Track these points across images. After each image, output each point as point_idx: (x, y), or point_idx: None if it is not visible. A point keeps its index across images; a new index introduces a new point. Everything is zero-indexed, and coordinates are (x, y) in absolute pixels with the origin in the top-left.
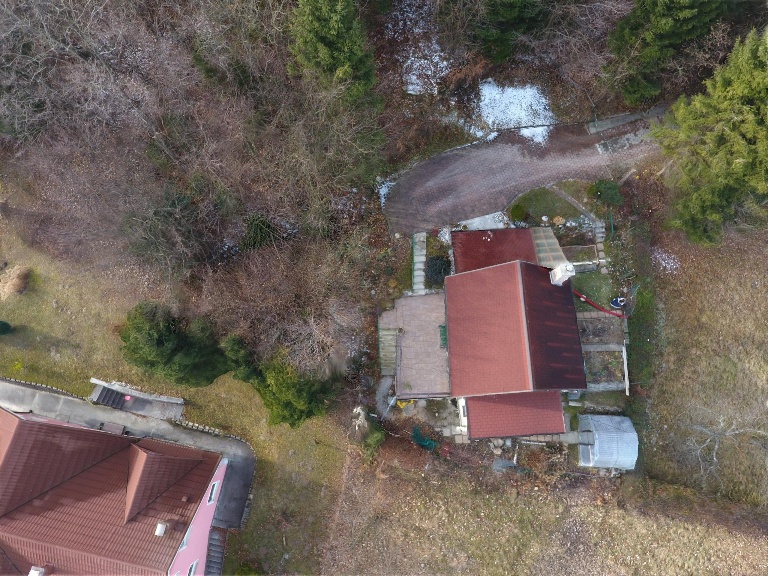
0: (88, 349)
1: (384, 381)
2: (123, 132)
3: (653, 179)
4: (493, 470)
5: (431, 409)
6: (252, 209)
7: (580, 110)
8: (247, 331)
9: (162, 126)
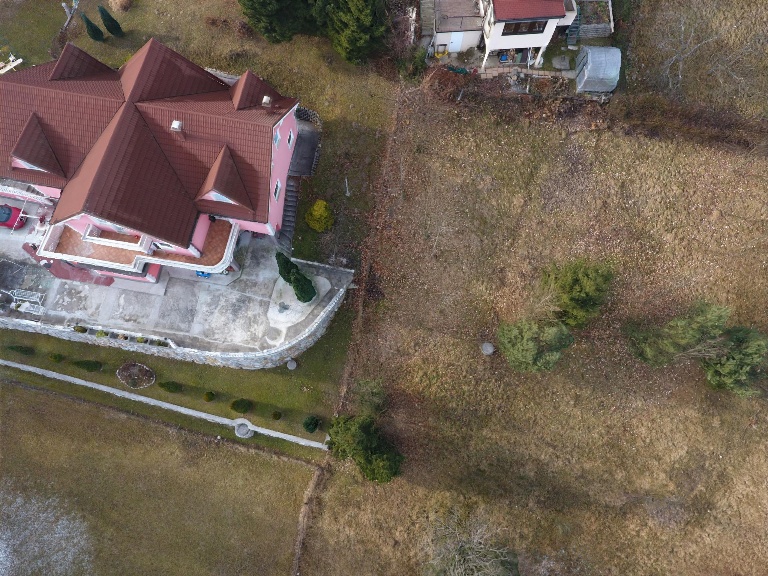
0: (186, 39)
1: (424, 40)
2: None
3: None
4: (511, 93)
5: (461, 58)
6: None
7: None
8: None
9: None
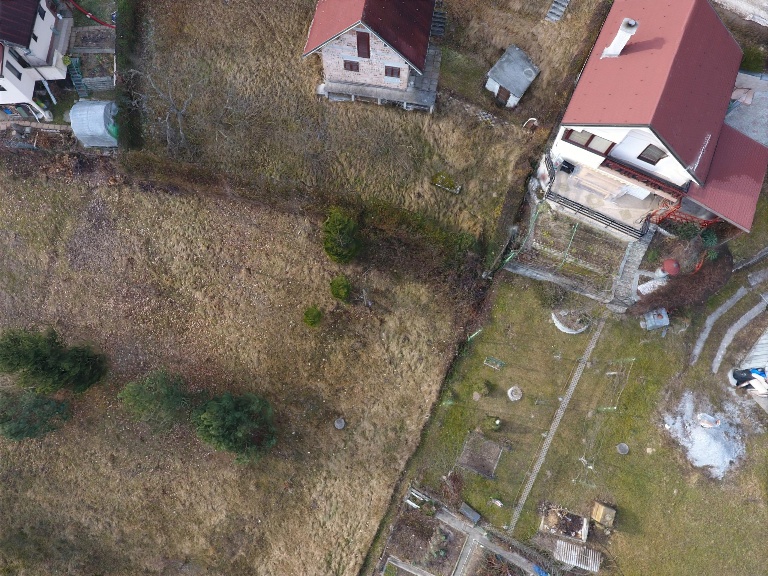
0: None
1: None
2: None
3: None
4: None
5: None
6: None
7: None
8: None
9: None
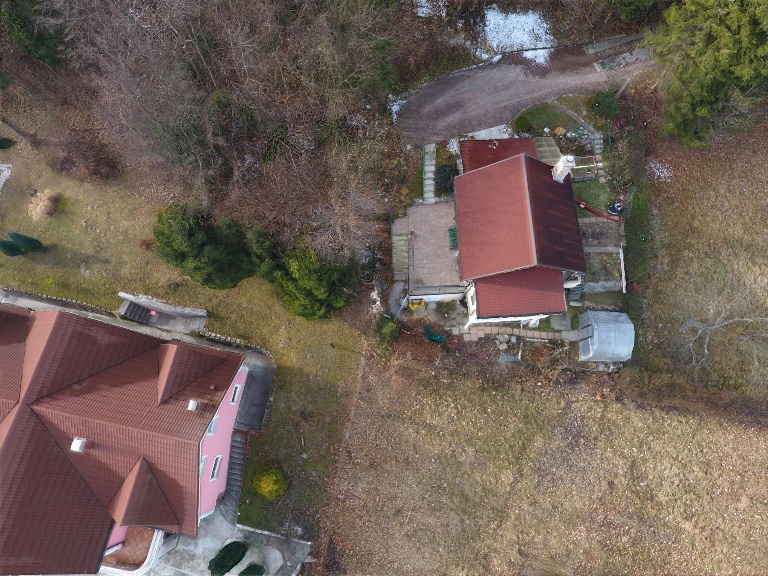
0: (117, 263)
1: (396, 286)
2: (148, 61)
3: (648, 93)
4: (499, 364)
5: (441, 311)
6: (272, 127)
7: (579, 32)
8: (272, 222)
9: (192, 33)
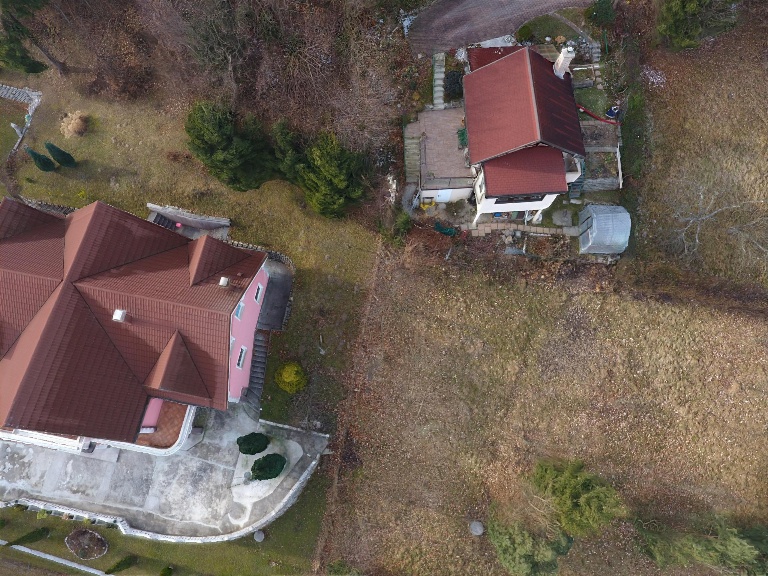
0: (145, 175)
1: (409, 188)
2: None
3: (642, 4)
4: (505, 255)
5: (450, 210)
6: (291, 42)
7: None
8: (296, 113)
9: None
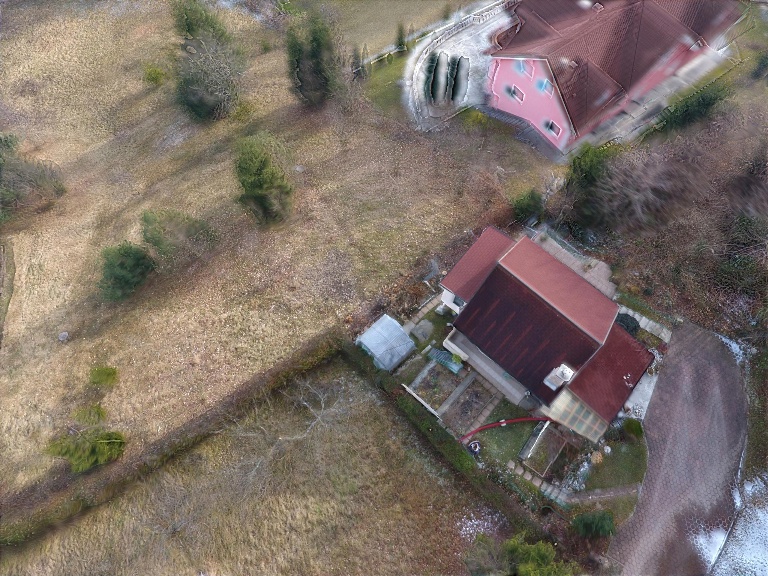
0: None
1: None
2: None
3: None
4: None
5: None
6: None
7: None
8: (680, 151)
9: None
